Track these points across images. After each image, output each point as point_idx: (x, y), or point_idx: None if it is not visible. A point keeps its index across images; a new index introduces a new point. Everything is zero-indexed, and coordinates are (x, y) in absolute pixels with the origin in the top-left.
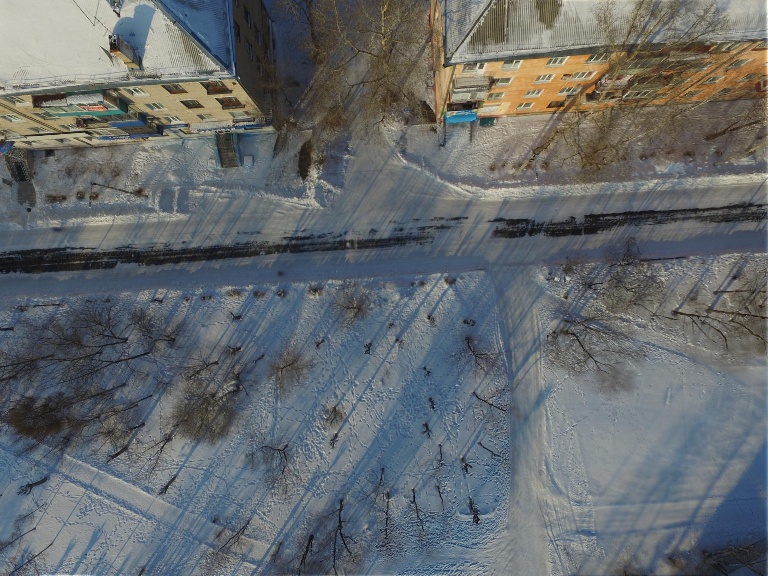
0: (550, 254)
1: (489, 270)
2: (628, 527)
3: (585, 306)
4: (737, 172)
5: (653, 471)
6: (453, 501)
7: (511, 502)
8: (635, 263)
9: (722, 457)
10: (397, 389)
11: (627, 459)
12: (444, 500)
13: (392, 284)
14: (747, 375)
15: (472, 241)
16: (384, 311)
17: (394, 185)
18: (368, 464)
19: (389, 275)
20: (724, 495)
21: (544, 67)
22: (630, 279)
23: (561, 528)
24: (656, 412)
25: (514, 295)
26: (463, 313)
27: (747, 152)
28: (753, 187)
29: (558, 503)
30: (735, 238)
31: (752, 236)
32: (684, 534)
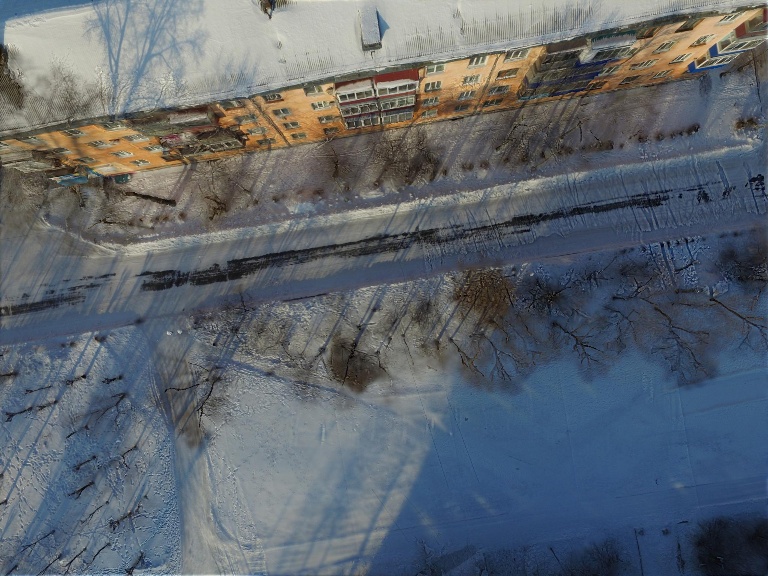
0: (198, 302)
1: (140, 324)
2: (299, 566)
3: (235, 351)
4: (365, 206)
5: (316, 508)
6: (125, 556)
7: (183, 552)
8: (277, 304)
9: (381, 488)
10: (61, 450)
11: (289, 499)
12: (116, 556)
13: (43, 347)
14: (398, 404)
15: (122, 297)
16: (42, 374)
17: (42, 249)
18: (38, 528)
19: (42, 338)
20: (388, 526)
21: (70, 138)
22: (274, 321)
23: (234, 573)
24: (313, 450)
25: (167, 346)
26: (118, 369)
27: (341, 191)
28: (386, 218)
29: (229, 549)
30: (375, 270)
31: (391, 267)
32: (353, 568)
